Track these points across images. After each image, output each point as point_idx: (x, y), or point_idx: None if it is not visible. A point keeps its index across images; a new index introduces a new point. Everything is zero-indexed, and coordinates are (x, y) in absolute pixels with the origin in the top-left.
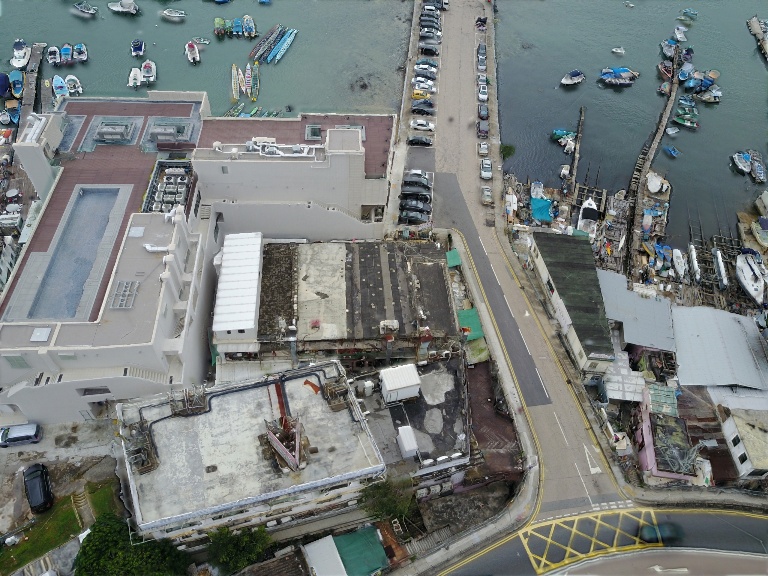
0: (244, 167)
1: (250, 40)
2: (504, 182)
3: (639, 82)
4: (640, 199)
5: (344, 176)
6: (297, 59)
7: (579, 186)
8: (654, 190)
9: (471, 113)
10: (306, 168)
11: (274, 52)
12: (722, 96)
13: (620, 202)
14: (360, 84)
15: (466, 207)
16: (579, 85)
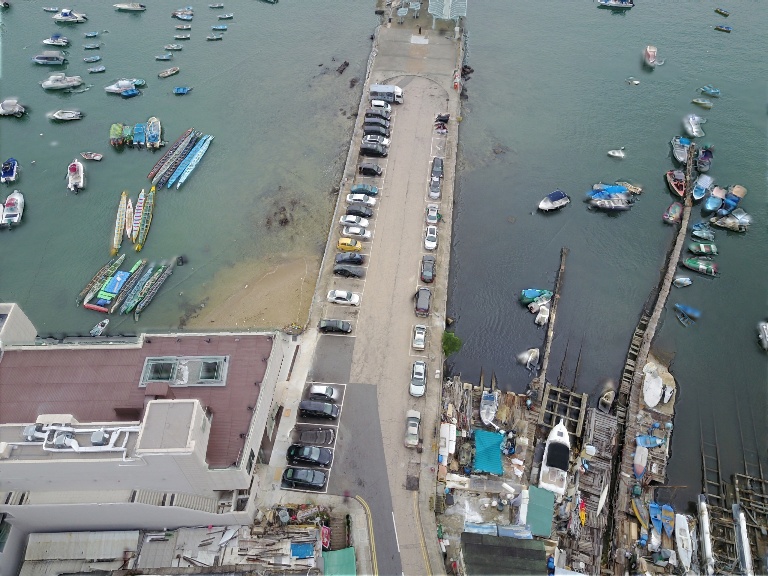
0: (21, 466)
1: (153, 152)
2: (443, 394)
3: (640, 205)
4: (633, 413)
5: (174, 470)
6: (207, 179)
7: (550, 388)
8: (652, 404)
9: (412, 271)
10: (113, 465)
11: (179, 170)
12: (749, 225)
13: (604, 419)
14: (279, 218)
15: (382, 451)
16: (562, 210)
